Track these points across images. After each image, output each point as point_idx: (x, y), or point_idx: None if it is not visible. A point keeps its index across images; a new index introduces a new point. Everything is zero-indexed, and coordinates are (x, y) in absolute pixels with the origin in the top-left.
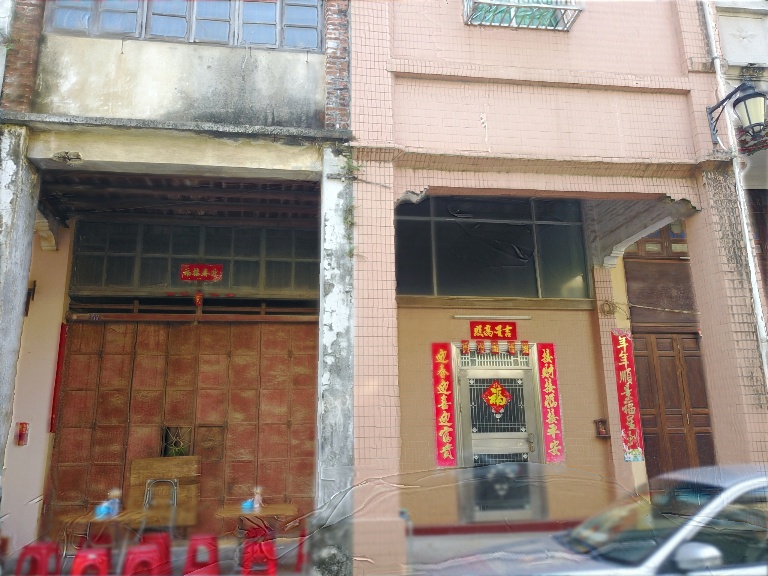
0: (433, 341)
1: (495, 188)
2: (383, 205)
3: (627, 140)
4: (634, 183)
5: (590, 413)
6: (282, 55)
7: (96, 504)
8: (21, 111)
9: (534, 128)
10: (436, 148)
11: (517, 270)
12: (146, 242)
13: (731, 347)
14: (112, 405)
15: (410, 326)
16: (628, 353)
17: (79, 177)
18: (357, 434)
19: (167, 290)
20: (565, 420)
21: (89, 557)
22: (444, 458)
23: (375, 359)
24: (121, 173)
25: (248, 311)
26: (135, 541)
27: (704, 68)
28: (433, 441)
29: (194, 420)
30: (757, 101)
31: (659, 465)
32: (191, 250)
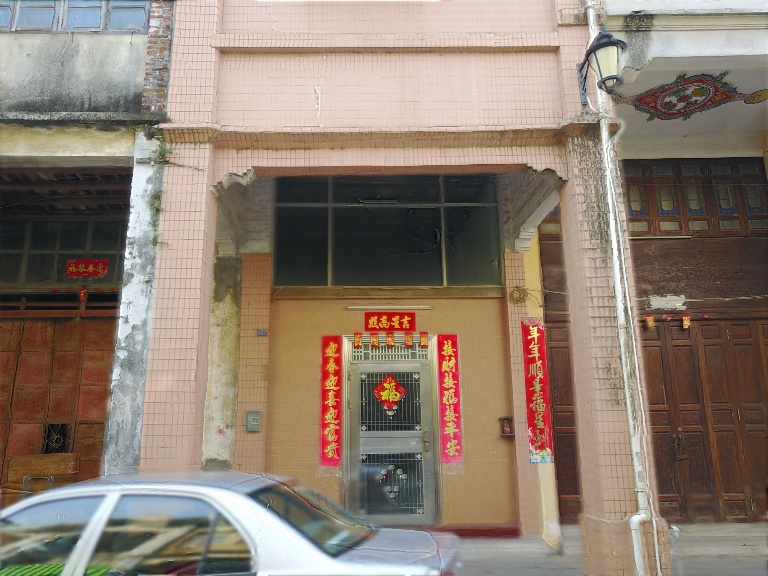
0: (323, 334)
1: (326, 166)
2: (194, 189)
3: (482, 106)
4: (489, 154)
5: (495, 410)
6: (105, 38)
7: None
8: None
9: (374, 99)
10: (261, 126)
11: (422, 257)
12: (34, 239)
13: (587, 335)
14: None
15: (299, 318)
16: (539, 344)
17: None
18: (145, 432)
19: (52, 286)
20: (465, 418)
21: None
22: (329, 458)
23: (171, 352)
24: None
25: None
26: None
27: (576, 20)
28: (318, 439)
29: (75, 417)
30: (608, 51)
31: (576, 468)
32: (78, 245)
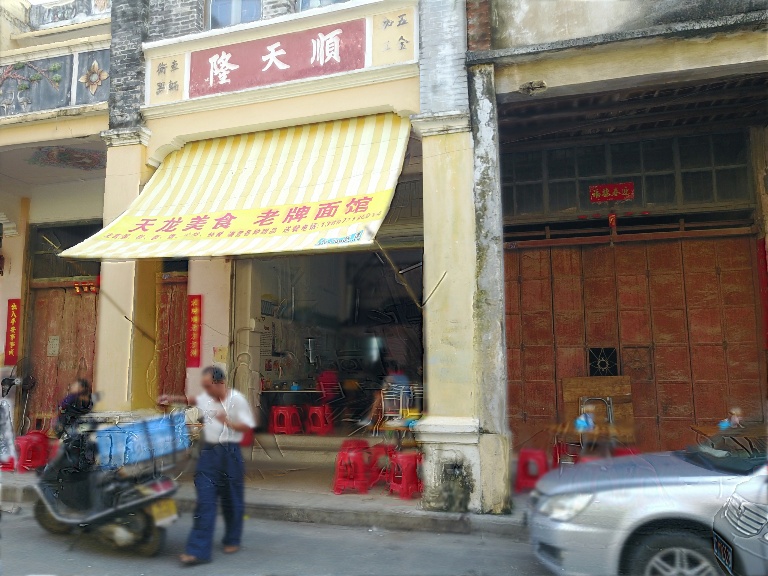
0: None
1: None
2: None
3: None
4: None
5: None
6: None
7: (533, 418)
8: (488, 50)
9: None
10: None
11: None
12: (551, 168)
13: None
14: (536, 327)
15: None
16: None
17: (508, 109)
18: None
19: (577, 214)
20: None
21: (595, 465)
22: None
23: None
24: (565, 97)
25: (665, 228)
26: (627, 453)
27: None
28: None
29: (618, 341)
30: None
31: None
32: (597, 170)
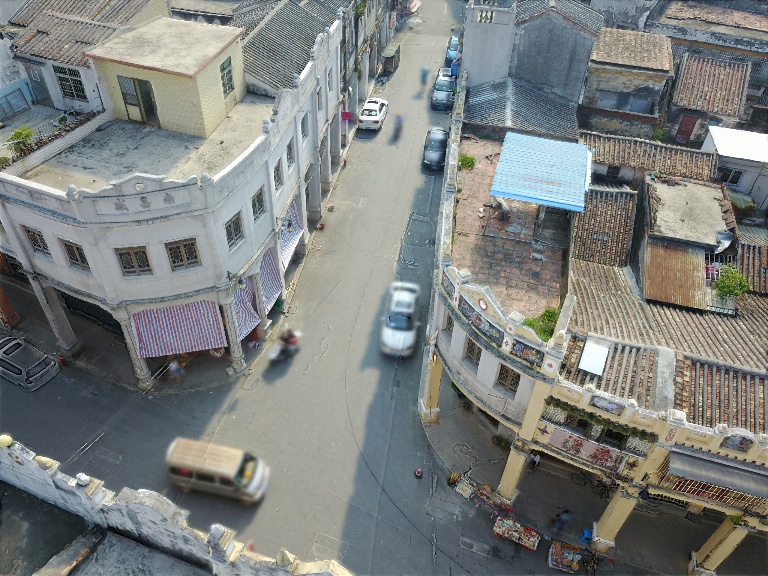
0: None
1: None
2: None
3: None
4: None
5: None
6: None
7: None
8: None
9: None
10: None
11: None
12: None
13: None
14: None
15: None
16: None
17: None
18: None
19: None
20: None
21: None
22: (2, 259)
23: None
24: None
25: None
26: None
27: None
28: None
29: None
30: None
31: None
32: None
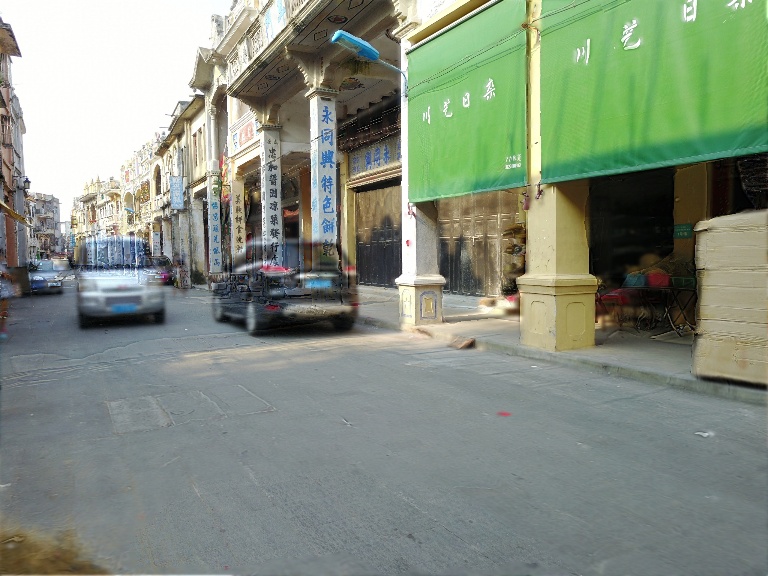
0: None
1: None
2: None
3: None
4: None
5: None
6: None
7: None
8: None
9: None
10: None
11: None
12: None
13: (14, 237)
14: None
15: None
16: None
17: None
18: None
19: None
20: None
21: None
22: None
23: None
24: None
25: None
26: None
27: None
28: None
29: None
30: None
31: None
32: None
